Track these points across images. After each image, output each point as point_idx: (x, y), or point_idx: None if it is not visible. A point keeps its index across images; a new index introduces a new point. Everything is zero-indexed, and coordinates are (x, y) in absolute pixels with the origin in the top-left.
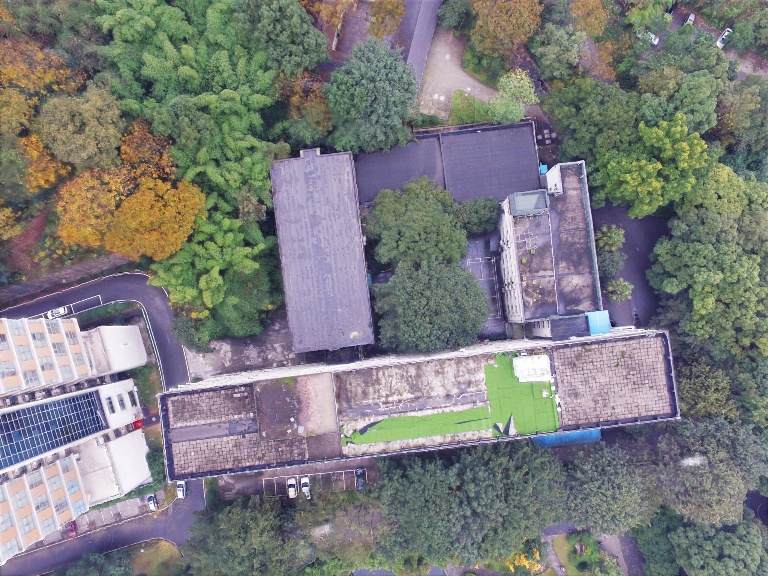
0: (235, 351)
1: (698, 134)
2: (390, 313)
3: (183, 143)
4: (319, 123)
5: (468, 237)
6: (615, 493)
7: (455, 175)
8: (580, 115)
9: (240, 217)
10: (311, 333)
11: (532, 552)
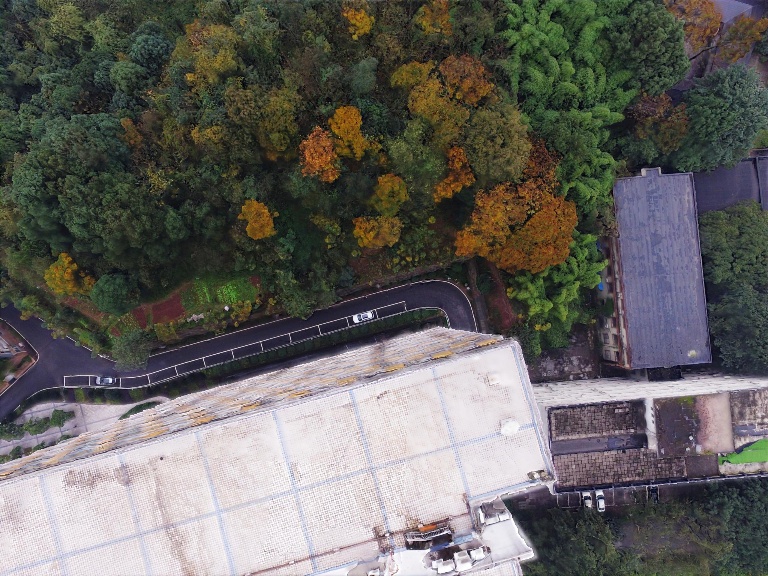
0: None
1: None
2: (727, 333)
3: (570, 159)
4: (667, 143)
5: None
6: None
7: None
8: None
9: (600, 233)
10: (650, 350)
11: None
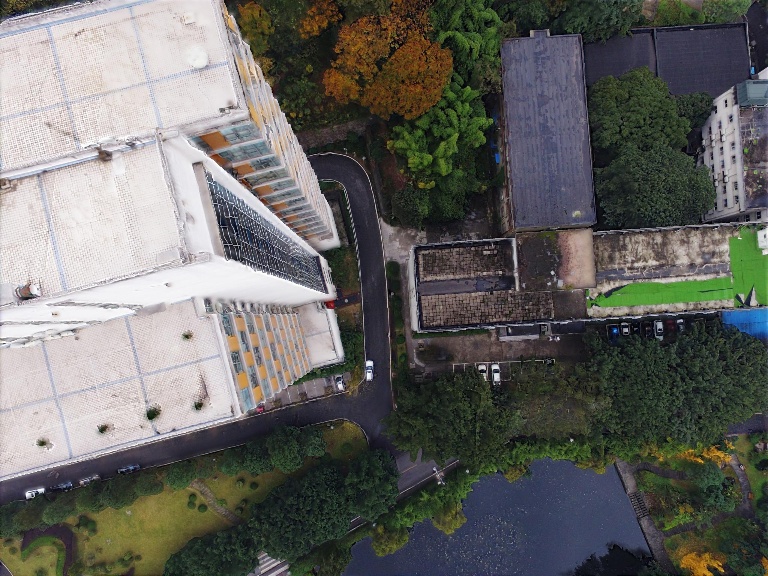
0: (431, 238)
1: None
2: (613, 194)
3: (443, 3)
4: (554, 3)
5: None
6: None
7: (667, 70)
8: None
9: (480, 87)
10: (534, 210)
11: (724, 443)
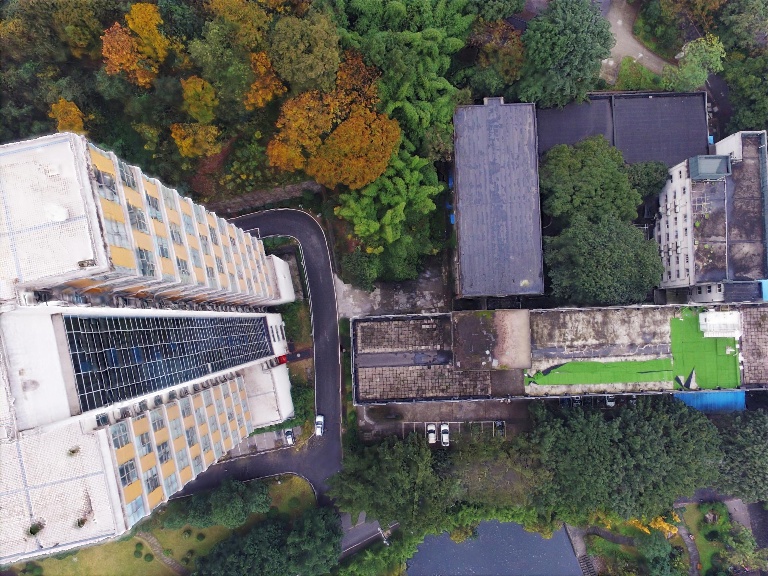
0: (385, 295)
1: None
2: (561, 265)
3: (390, 76)
4: (508, 72)
5: None
6: None
7: (624, 138)
8: (763, 86)
9: (429, 156)
10: (482, 278)
11: (671, 515)
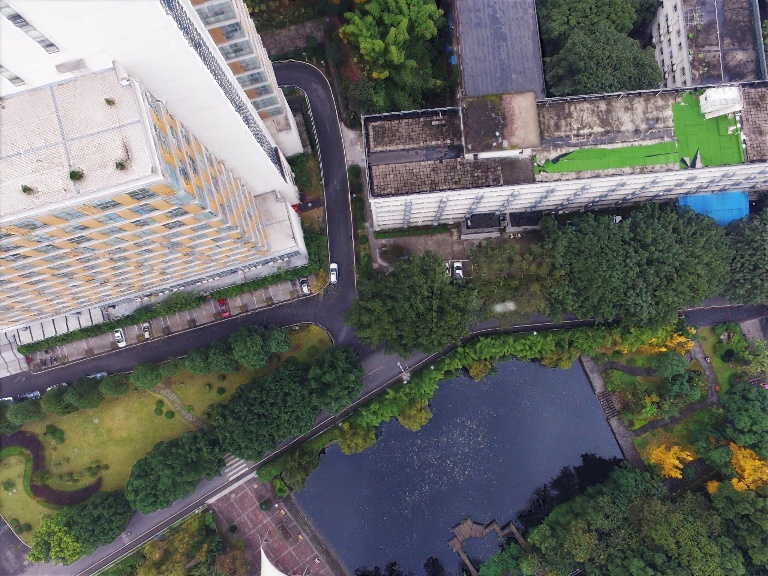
0: None
1: None
2: (562, 80)
3: None
4: None
5: None
6: None
7: None
8: None
9: None
10: None
11: (686, 329)
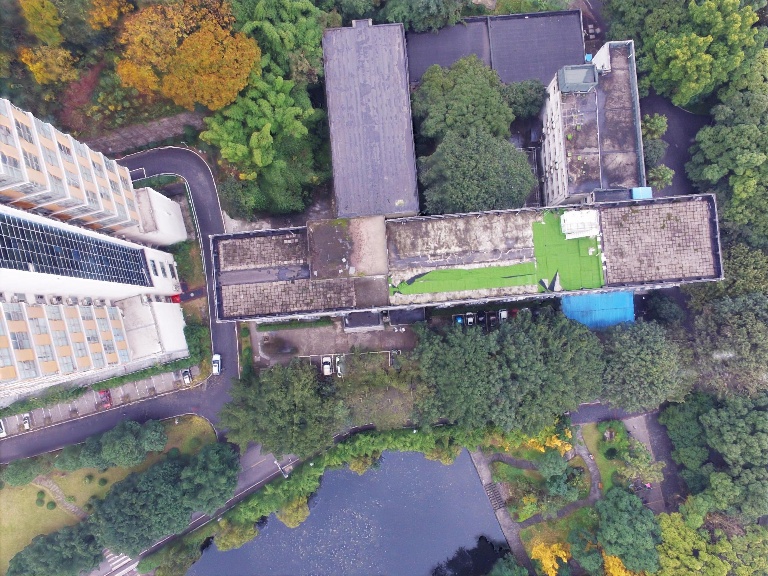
0: None
1: (750, 7)
2: (436, 183)
3: None
4: None
5: (511, 124)
6: (654, 358)
7: (502, 59)
8: None
9: (293, 77)
10: (357, 199)
11: (564, 432)
